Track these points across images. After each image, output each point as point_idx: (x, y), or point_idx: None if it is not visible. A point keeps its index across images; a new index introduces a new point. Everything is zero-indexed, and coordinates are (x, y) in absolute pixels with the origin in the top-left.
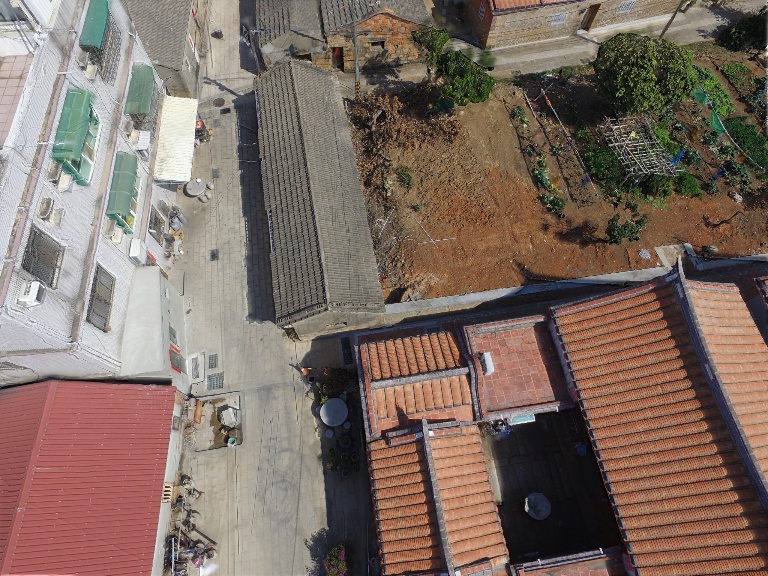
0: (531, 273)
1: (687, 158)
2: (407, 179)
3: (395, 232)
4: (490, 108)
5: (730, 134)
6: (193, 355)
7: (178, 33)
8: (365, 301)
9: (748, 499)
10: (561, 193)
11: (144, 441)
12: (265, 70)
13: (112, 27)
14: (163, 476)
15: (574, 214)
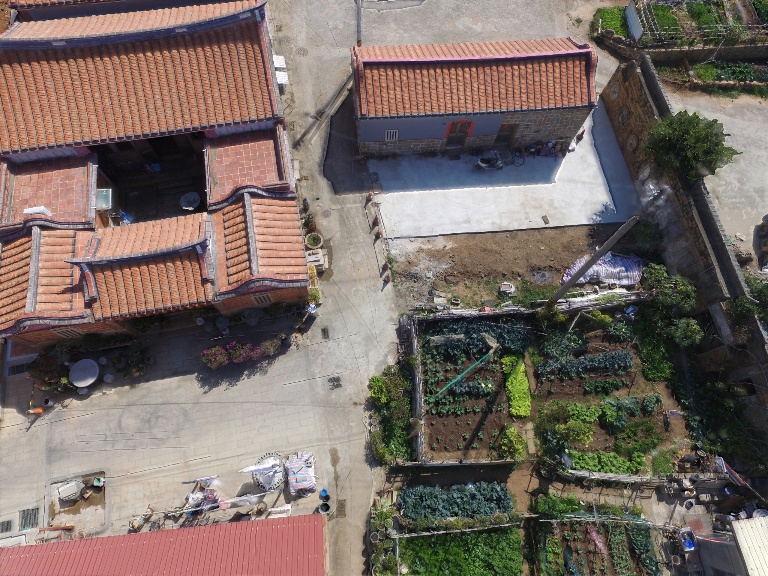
0: None
1: None
2: None
3: None
4: None
5: None
6: None
7: None
8: None
9: (159, 46)
10: None
11: (51, 571)
12: None
13: None
14: (99, 539)
15: None
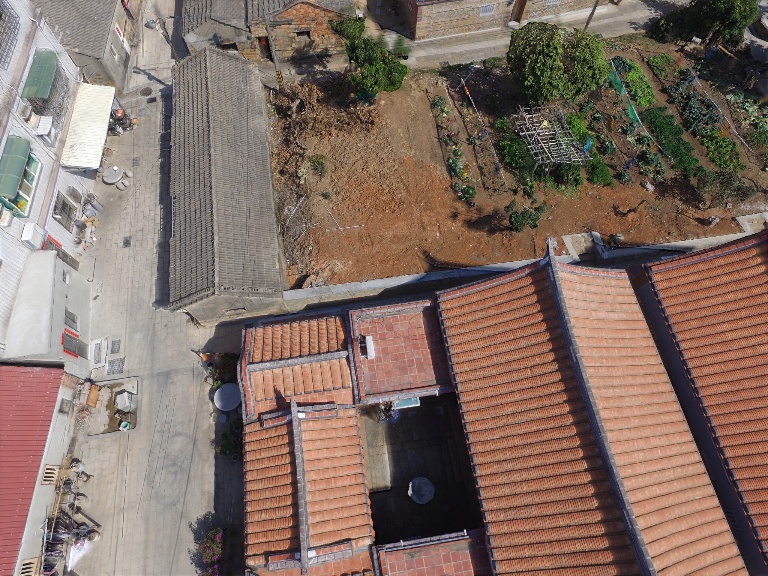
0: (435, 260)
1: (602, 148)
2: (320, 167)
3: (305, 220)
4: (412, 98)
5: (649, 124)
6: (96, 340)
7: (102, 22)
8: (259, 286)
9: (600, 480)
10: (474, 182)
11: (23, 423)
12: (182, 58)
13: (6, 11)
14: (40, 457)
15: (485, 202)
